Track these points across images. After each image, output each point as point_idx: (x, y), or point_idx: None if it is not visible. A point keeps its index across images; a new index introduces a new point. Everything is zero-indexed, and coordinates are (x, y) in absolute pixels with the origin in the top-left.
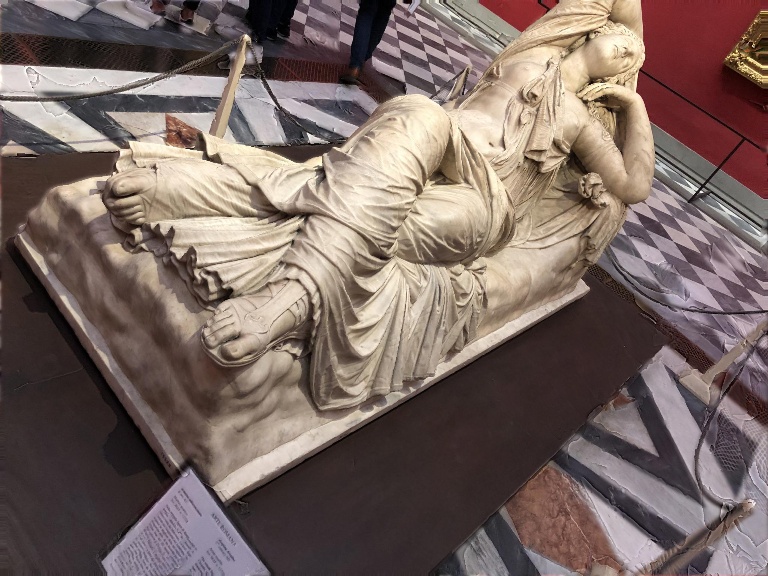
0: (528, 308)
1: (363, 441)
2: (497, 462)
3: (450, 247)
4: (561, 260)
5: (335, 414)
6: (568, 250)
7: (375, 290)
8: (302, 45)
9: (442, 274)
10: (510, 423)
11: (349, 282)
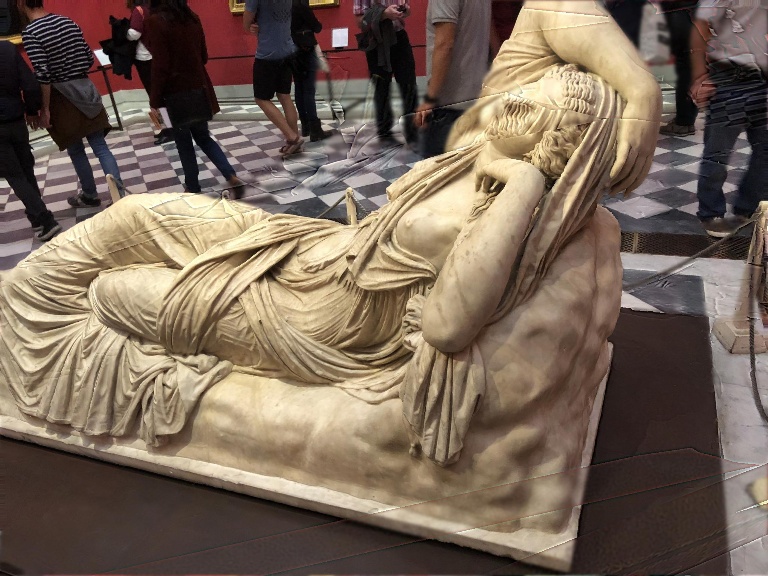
0: (332, 483)
1: (46, 461)
2: (52, 547)
3: (107, 311)
4: (375, 426)
5: (27, 417)
6: (386, 414)
7: (32, 319)
8: (734, 220)
9: (115, 340)
10: (124, 547)
11: (6, 302)
